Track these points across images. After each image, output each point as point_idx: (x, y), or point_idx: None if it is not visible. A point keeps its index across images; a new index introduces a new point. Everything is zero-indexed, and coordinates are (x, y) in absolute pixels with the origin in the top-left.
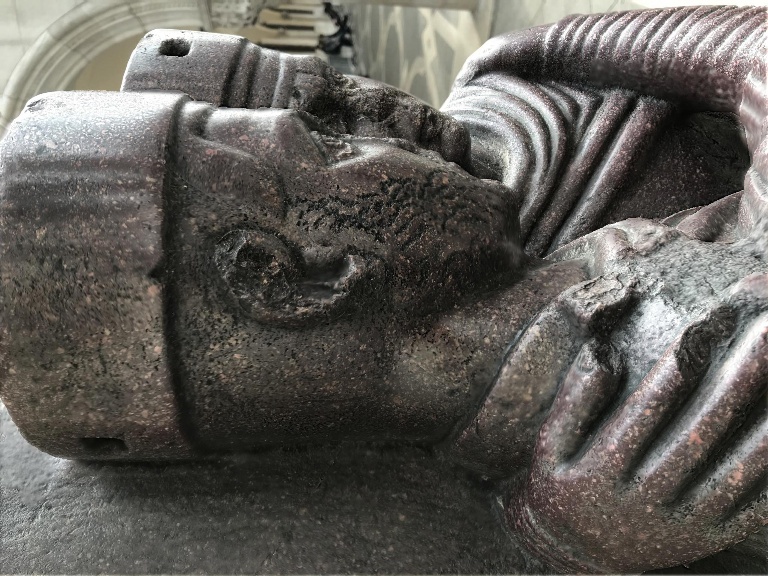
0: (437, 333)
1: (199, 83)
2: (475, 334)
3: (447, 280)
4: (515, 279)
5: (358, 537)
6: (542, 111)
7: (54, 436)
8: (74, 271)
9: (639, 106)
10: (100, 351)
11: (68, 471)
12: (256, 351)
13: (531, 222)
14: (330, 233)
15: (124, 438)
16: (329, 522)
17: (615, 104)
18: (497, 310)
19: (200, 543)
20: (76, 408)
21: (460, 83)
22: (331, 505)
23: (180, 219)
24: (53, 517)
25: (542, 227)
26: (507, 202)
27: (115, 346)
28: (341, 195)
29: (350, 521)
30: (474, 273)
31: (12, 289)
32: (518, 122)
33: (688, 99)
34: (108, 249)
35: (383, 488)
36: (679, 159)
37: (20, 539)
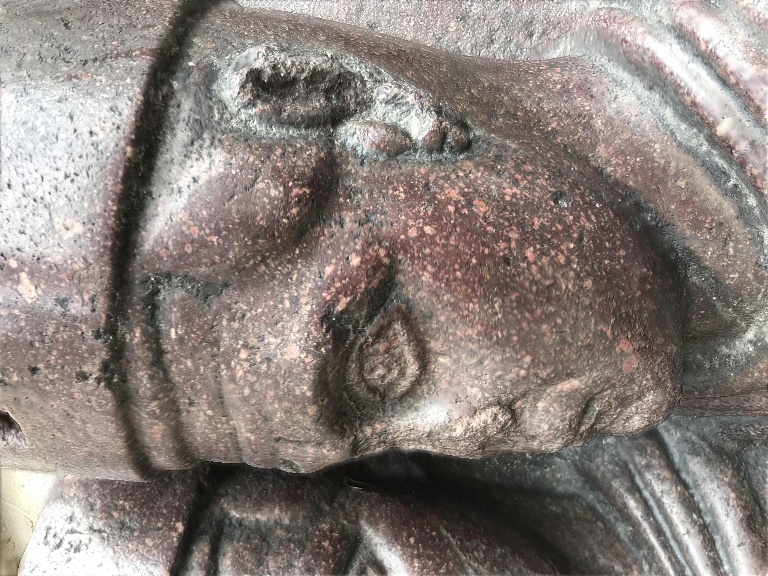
0: None
1: (95, 477)
2: None
3: None
4: None
5: None
6: None
7: None
8: None
9: None
10: None
11: None
12: None
13: None
14: None
15: None
16: None
17: None
18: None
19: None
20: None
21: None
22: None
23: None
24: None
25: (745, 411)
26: None
27: None
28: None
29: None
30: None
31: None
32: None
33: None
34: None
35: None
36: None
37: None
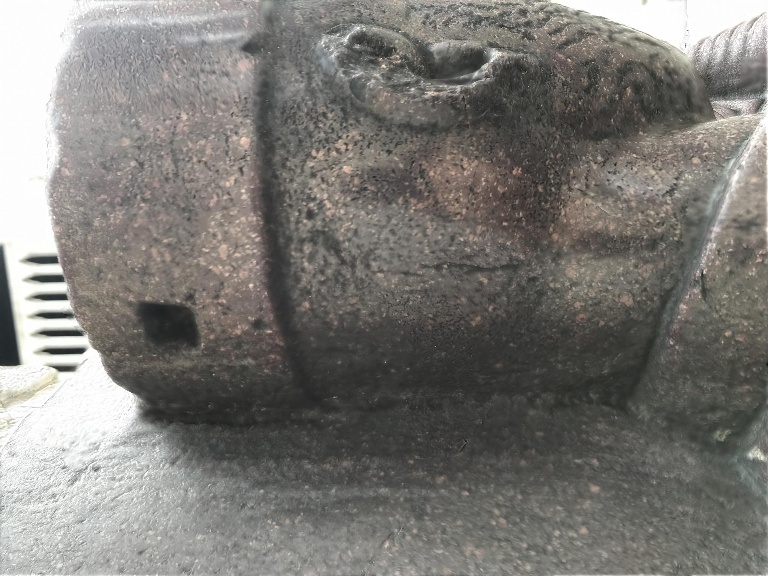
0: (620, 161)
1: None
2: (676, 157)
3: (624, 93)
4: None
5: (529, 513)
6: None
7: (107, 297)
8: (153, 45)
9: None
10: (173, 143)
11: (128, 427)
12: (372, 162)
13: None
14: (464, 31)
15: (195, 305)
16: (481, 493)
17: None
18: (703, 130)
19: (291, 515)
20: (137, 238)
21: None
22: (482, 471)
23: (282, 9)
24: (99, 479)
25: None
26: None
27: (192, 136)
28: (475, 2)
29: (514, 492)
30: (660, 96)
31: (80, 65)
32: None
33: None
34: (195, 24)
35: (559, 452)
36: None
37: (52, 504)
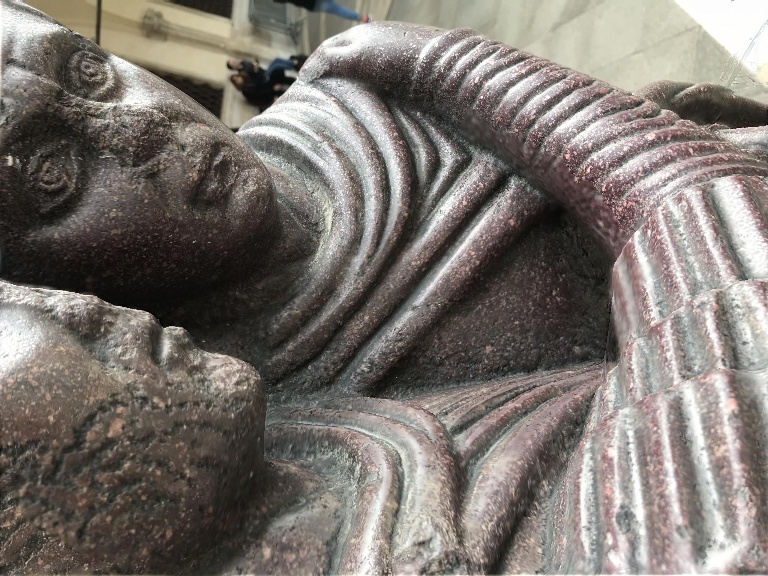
0: None
1: None
2: None
3: None
4: (218, 564)
5: None
6: (389, 163)
7: None
8: None
9: (508, 189)
10: None
11: None
12: None
13: (335, 325)
14: None
15: None
16: None
17: (481, 177)
18: None
19: None
20: None
21: (305, 76)
22: None
23: None
24: None
25: (348, 333)
26: (232, 439)
27: None
28: None
29: None
30: None
31: None
32: (355, 171)
33: (564, 207)
34: None
35: None
36: (536, 272)
37: None
